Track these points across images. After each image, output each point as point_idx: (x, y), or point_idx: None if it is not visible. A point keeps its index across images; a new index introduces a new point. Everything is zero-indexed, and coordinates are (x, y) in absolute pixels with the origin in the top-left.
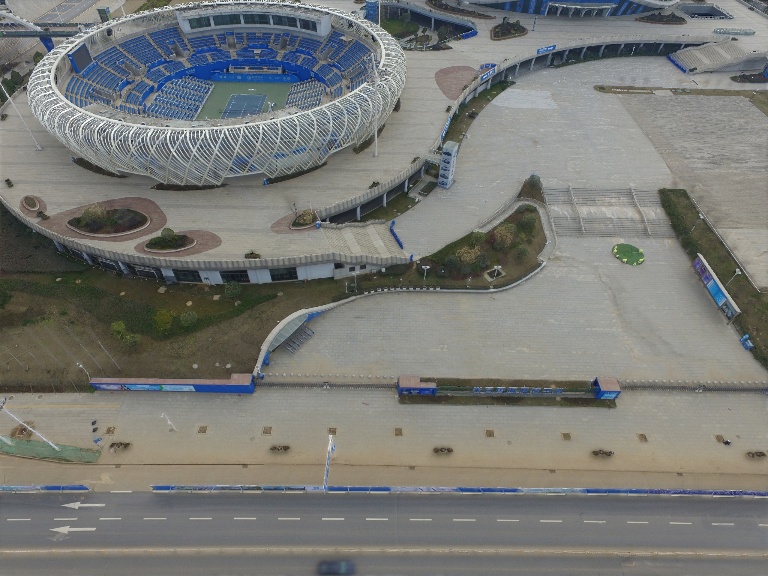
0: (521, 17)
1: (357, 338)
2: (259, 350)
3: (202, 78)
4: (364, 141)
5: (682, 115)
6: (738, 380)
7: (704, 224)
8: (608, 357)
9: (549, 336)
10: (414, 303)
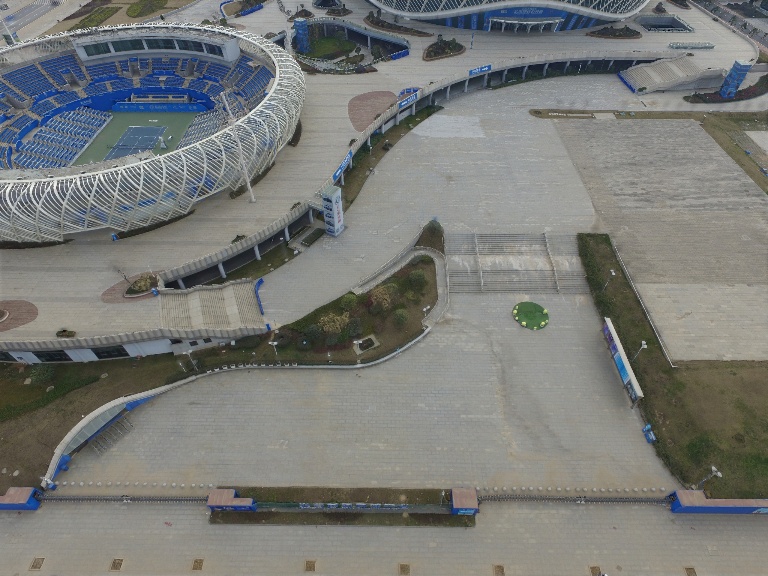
0: (462, 34)
1: (184, 432)
2: (52, 454)
3: (101, 108)
4: (245, 183)
5: (621, 143)
6: (632, 486)
7: (622, 277)
8: (479, 455)
9: (414, 426)
10: (264, 383)
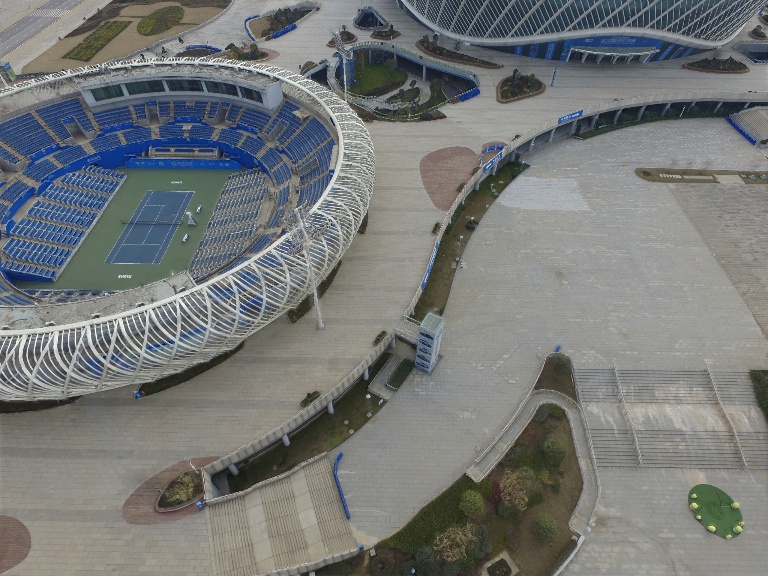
0: (536, 65)
1: None
2: None
3: (113, 165)
4: (306, 296)
5: (762, 221)
6: None
7: None
8: None
9: None
10: None
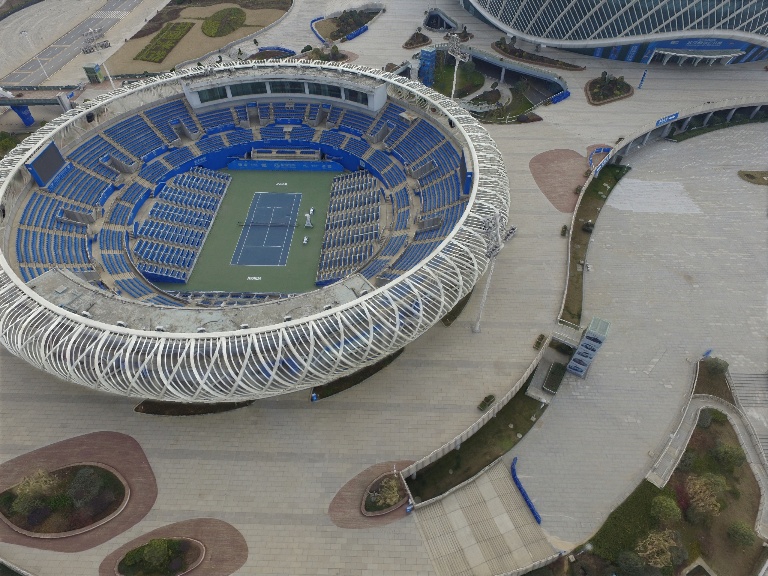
0: (618, 67)
1: None
2: None
3: (215, 166)
4: None
5: None
6: None
7: None
8: None
9: None
10: None
